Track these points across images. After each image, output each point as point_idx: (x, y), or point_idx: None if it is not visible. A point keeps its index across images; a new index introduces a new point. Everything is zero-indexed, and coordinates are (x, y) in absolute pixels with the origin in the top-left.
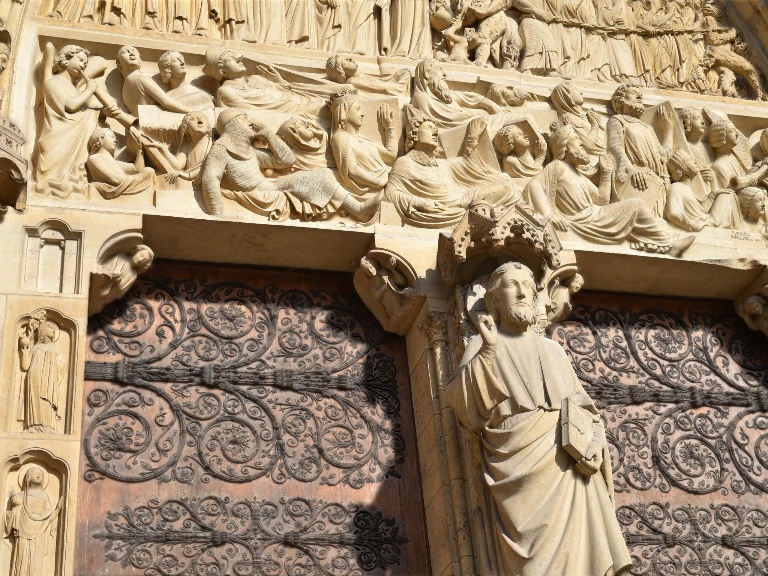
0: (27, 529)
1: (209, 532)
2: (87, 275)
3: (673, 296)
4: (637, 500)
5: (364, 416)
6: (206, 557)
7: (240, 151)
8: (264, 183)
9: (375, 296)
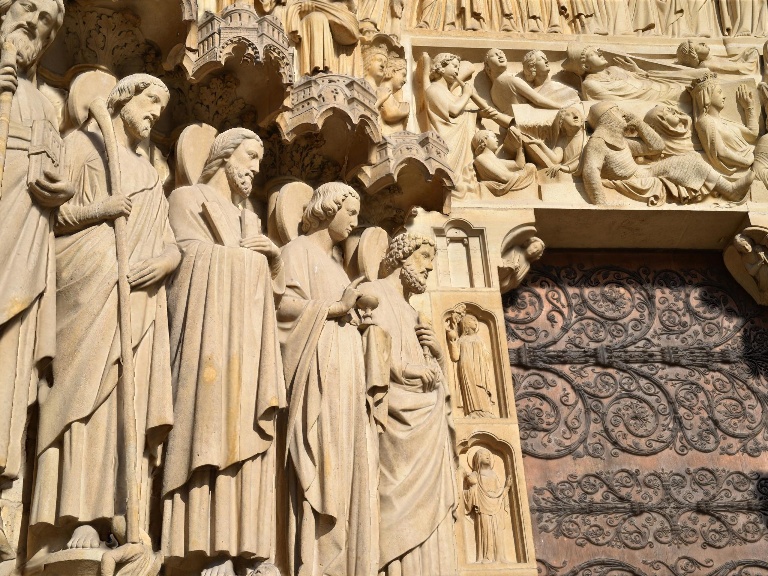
0: (487, 506)
1: (627, 503)
2: (495, 269)
3: None
4: None
5: (751, 387)
6: (628, 526)
7: (617, 142)
8: (639, 171)
9: (751, 272)
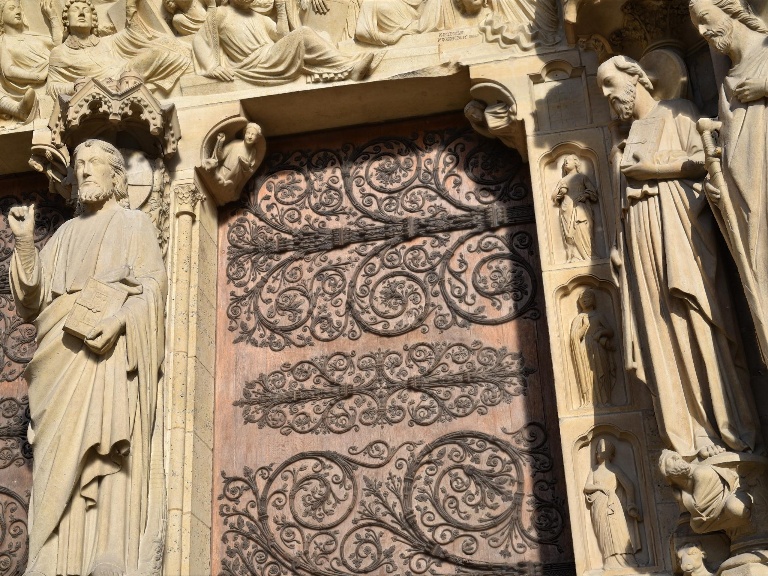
0: None
1: None
2: None
3: (403, 119)
4: (320, 353)
5: None
6: None
7: None
8: None
9: (50, 191)
